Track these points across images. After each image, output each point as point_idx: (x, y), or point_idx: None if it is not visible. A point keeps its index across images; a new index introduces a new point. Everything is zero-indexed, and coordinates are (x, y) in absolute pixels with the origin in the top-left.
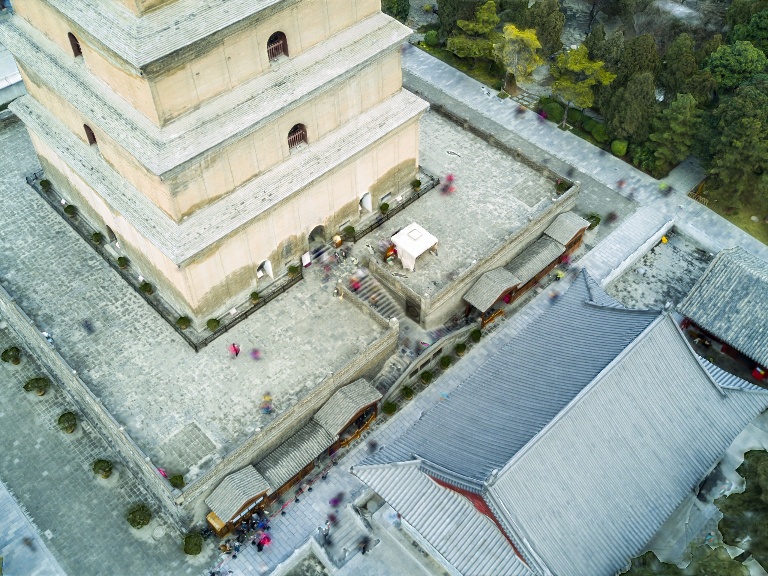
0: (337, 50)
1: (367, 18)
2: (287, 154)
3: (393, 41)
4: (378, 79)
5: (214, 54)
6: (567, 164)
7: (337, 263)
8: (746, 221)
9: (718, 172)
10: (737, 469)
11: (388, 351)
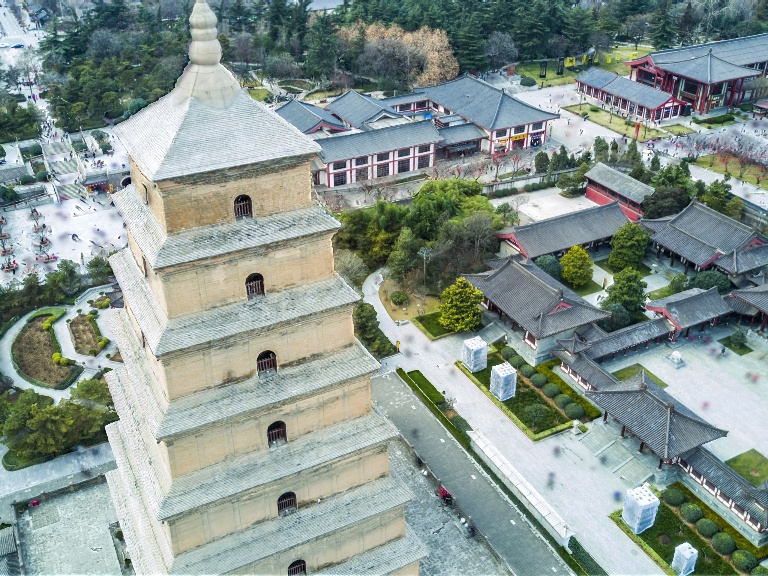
0: None
1: None
2: None
3: (155, 574)
4: None
5: None
6: None
7: None
8: None
9: None
10: None
11: None
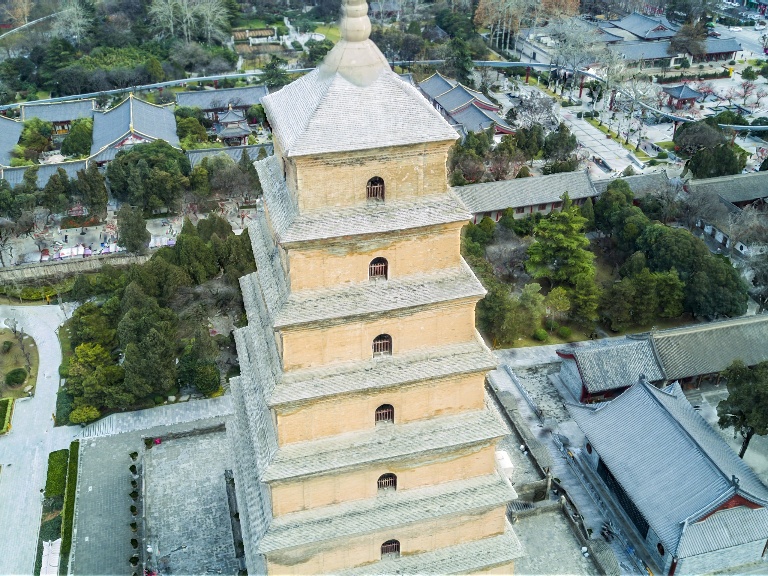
0: None
1: None
2: None
3: None
4: None
5: None
6: None
7: None
8: (520, 343)
9: (506, 327)
10: (719, 415)
11: None
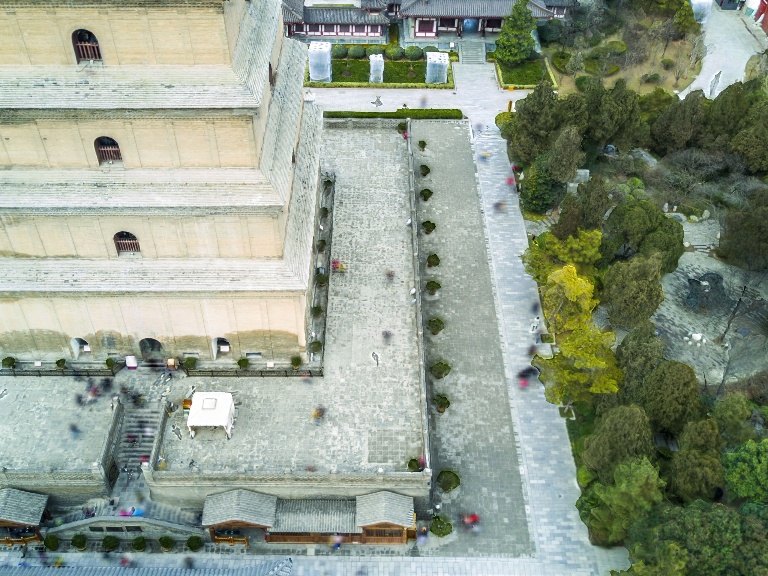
0: (182, 183)
1: (236, 168)
2: (114, 254)
3: (252, 203)
4: (242, 233)
5: (26, 128)
6: (515, 451)
7: (153, 383)
8: None
9: None
10: None
11: (93, 490)
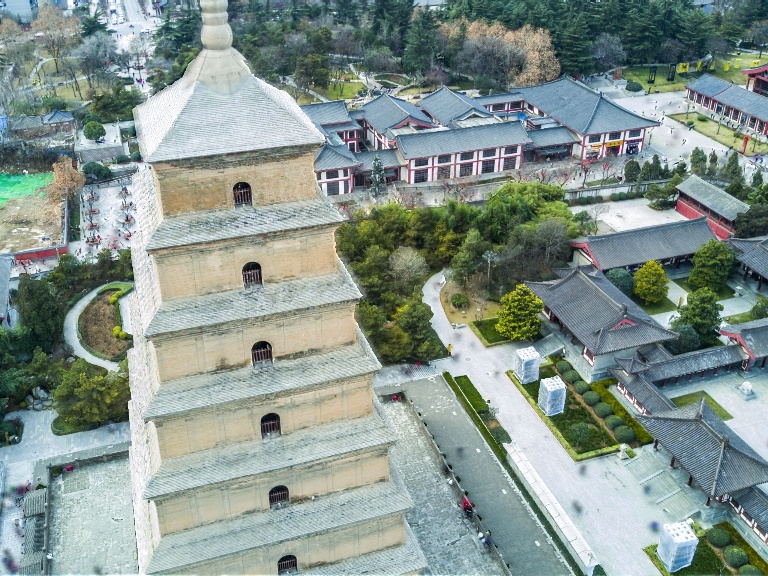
0: None
1: None
2: None
3: None
4: None
5: None
6: None
7: None
8: None
9: None
10: None
11: None
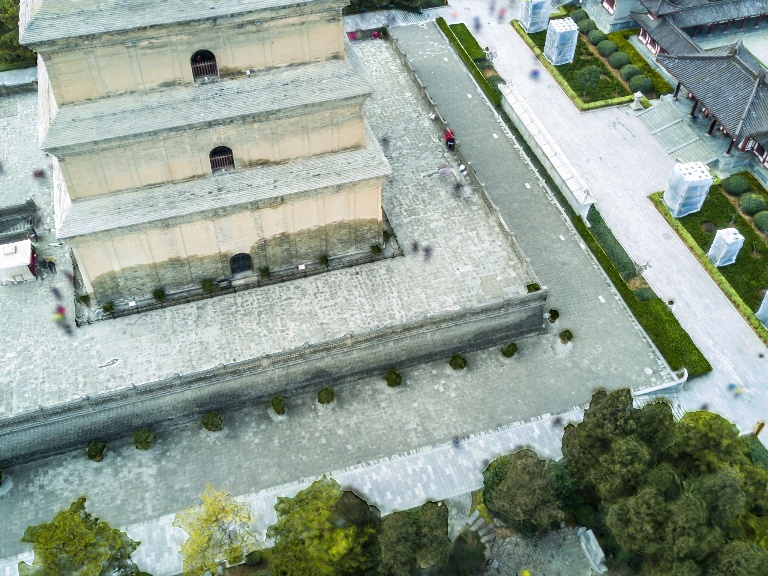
0: None
1: None
2: None
3: None
4: None
5: None
6: None
7: None
8: None
9: None
10: None
11: None
